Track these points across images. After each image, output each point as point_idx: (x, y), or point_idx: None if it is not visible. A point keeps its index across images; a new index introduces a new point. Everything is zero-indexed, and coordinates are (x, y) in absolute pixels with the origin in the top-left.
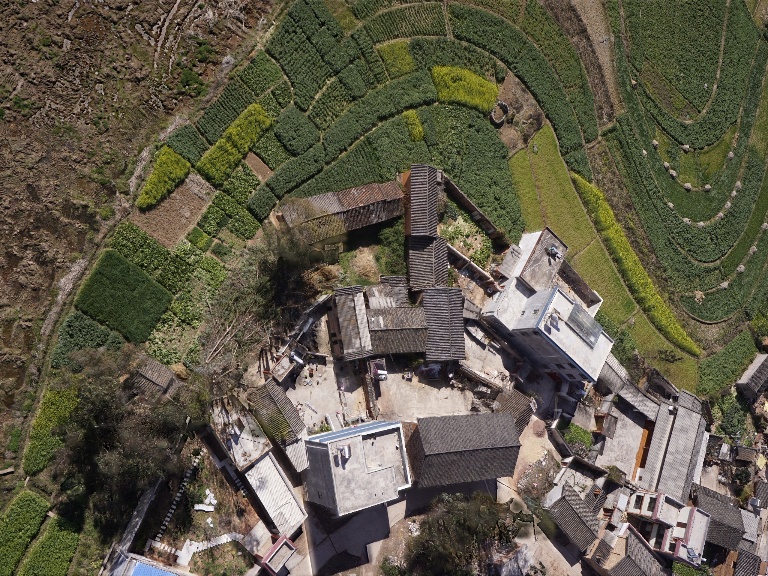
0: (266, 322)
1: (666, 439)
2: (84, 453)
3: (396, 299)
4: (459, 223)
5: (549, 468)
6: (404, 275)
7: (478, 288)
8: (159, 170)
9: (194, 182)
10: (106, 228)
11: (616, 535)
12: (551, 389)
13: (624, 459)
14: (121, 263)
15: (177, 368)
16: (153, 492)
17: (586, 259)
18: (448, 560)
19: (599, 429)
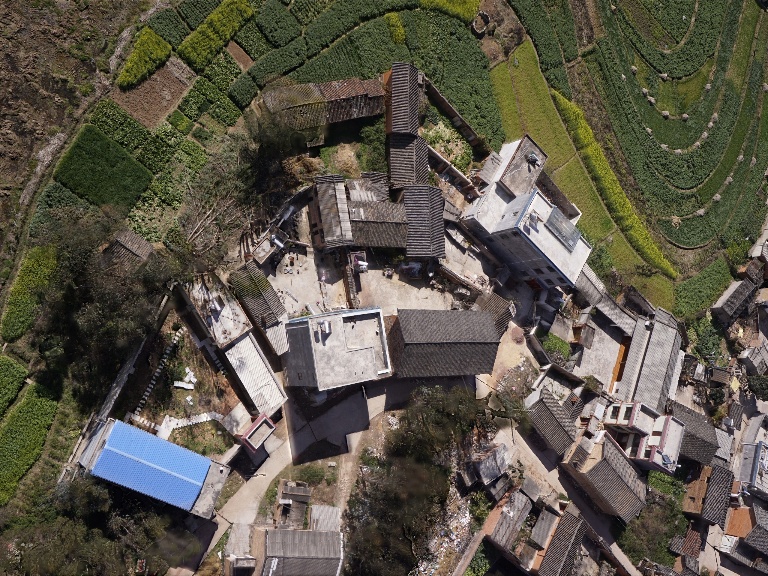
0: (247, 208)
1: (642, 353)
2: (63, 323)
3: (377, 195)
4: (440, 128)
5: (527, 373)
6: (385, 173)
7: (458, 193)
8: (140, 49)
9: (175, 66)
10: (86, 104)
11: (593, 442)
12: (530, 298)
13: (601, 372)
14: (101, 139)
15: (157, 246)
16: (132, 362)
17: (565, 175)
18: (427, 448)
19: (577, 339)
